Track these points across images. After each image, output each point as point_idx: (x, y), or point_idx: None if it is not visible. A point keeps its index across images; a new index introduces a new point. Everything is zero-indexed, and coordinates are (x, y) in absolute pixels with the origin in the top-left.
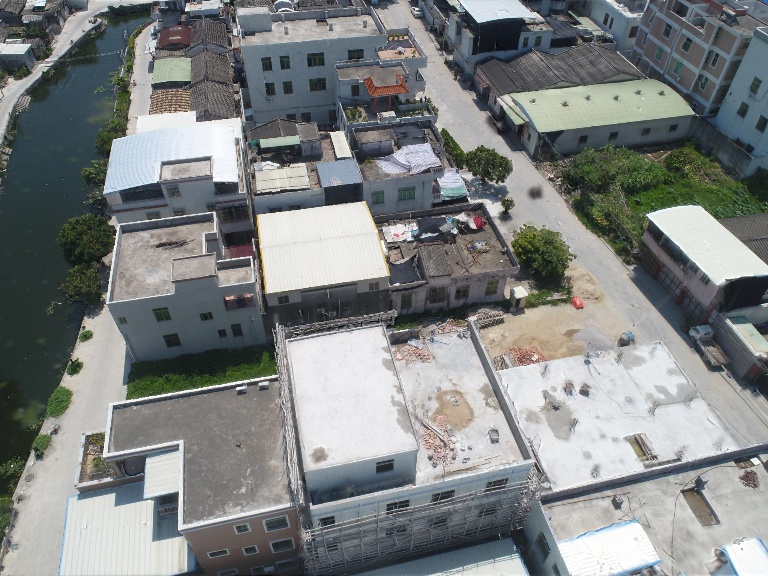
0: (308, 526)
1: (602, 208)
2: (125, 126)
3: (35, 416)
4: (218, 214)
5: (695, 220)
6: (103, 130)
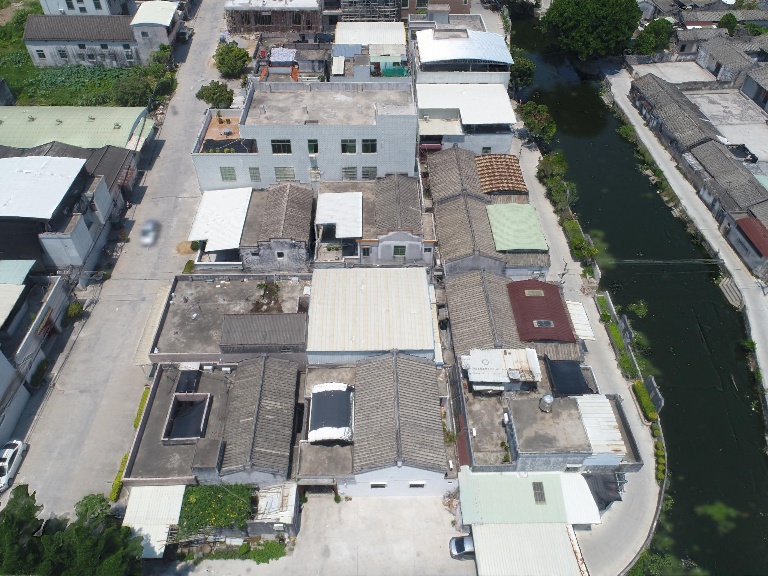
0: None
1: (158, 80)
2: None
3: None
4: None
5: (148, 17)
6: None
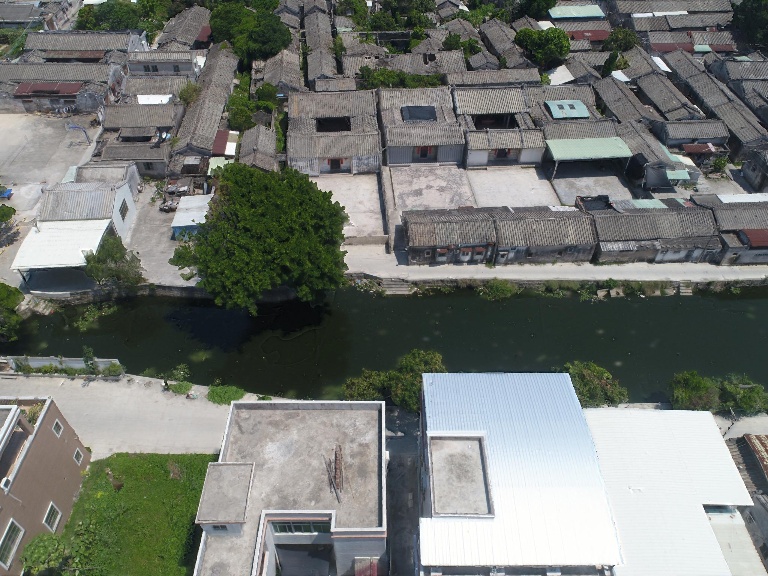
0: None
1: None
2: (750, 408)
3: (230, 381)
4: None
5: None
6: None
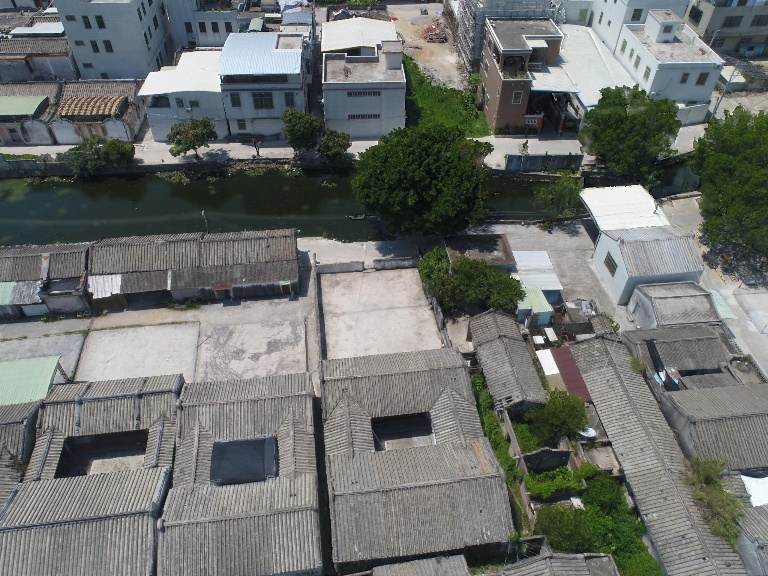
0: (555, 23)
1: None
2: None
3: None
4: (308, 68)
5: None
6: (82, 158)
